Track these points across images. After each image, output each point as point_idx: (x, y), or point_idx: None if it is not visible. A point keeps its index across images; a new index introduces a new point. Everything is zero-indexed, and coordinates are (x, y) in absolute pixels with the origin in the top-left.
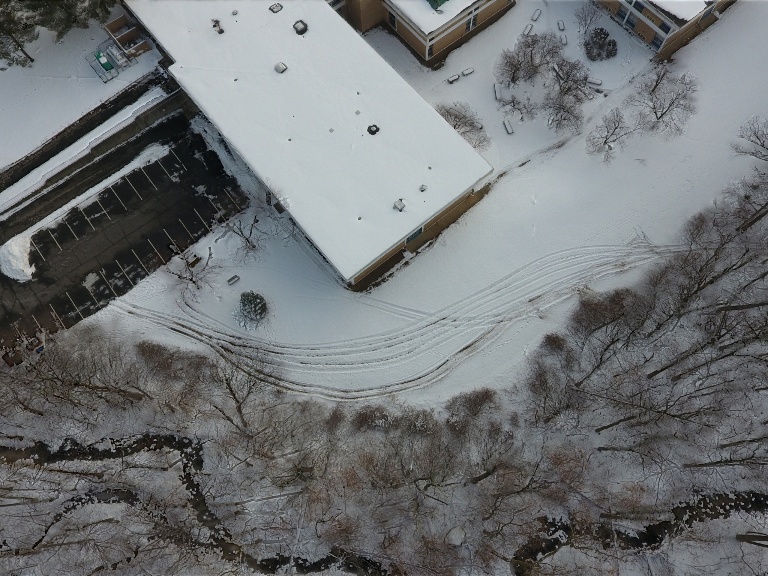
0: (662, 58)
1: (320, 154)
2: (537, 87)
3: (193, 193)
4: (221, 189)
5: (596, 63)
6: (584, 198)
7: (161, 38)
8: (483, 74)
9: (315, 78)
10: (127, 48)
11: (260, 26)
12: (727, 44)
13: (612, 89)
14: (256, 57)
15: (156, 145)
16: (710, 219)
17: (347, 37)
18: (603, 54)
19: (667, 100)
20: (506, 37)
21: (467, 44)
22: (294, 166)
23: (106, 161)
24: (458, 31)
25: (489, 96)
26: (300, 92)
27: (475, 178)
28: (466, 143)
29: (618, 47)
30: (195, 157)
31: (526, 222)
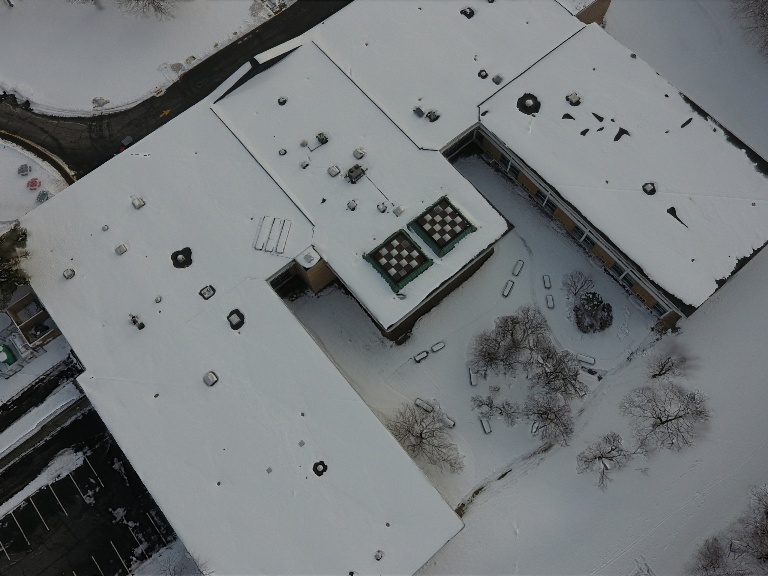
0: (665, 326)
1: (255, 505)
2: (519, 378)
3: (110, 519)
4: (143, 513)
5: (588, 336)
6: (576, 525)
7: (69, 336)
8: (456, 349)
9: (251, 393)
10: (34, 332)
11: (188, 318)
12: (741, 306)
13: (607, 370)
14: (182, 363)
15: (68, 452)
16: (726, 544)
17: (291, 333)
18: (596, 325)
19: (673, 409)
20: (483, 298)
21: (437, 308)
22: (223, 523)
23: (8, 476)
24: None
25: (463, 379)
26: (233, 414)
27: (442, 540)
28: (432, 488)
29: (614, 313)
30: (114, 468)
31: (507, 561)
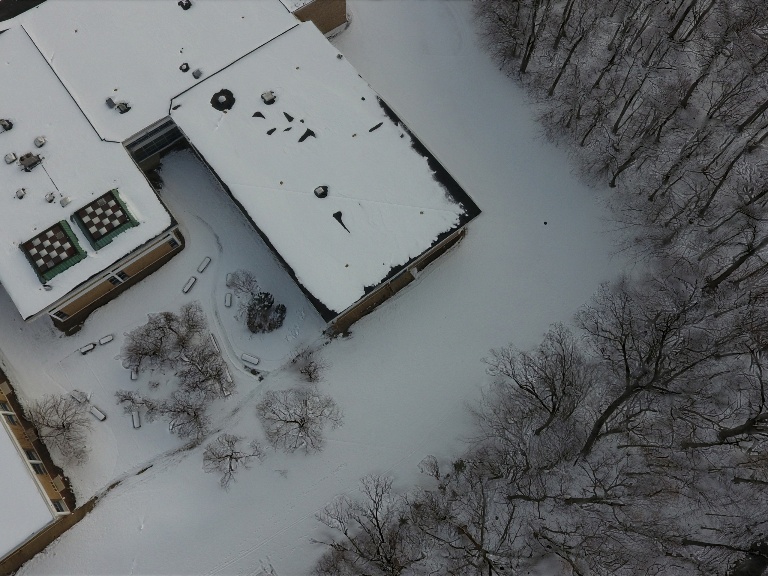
0: (337, 330)
1: None
2: None
3: None
4: None
5: (256, 336)
6: (202, 523)
7: None
8: None
9: None
10: None
11: None
12: (417, 314)
13: (269, 371)
14: None
15: None
16: None
17: None
18: (265, 326)
19: None
20: (162, 293)
21: (115, 301)
22: None
23: None
24: (99, 289)
25: (125, 373)
26: None
27: (27, 533)
28: (30, 480)
29: (287, 314)
30: None
31: (125, 555)
